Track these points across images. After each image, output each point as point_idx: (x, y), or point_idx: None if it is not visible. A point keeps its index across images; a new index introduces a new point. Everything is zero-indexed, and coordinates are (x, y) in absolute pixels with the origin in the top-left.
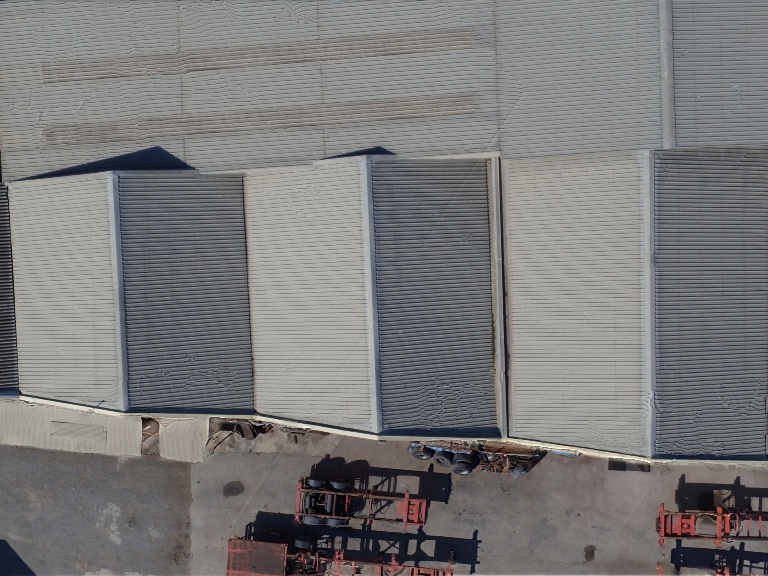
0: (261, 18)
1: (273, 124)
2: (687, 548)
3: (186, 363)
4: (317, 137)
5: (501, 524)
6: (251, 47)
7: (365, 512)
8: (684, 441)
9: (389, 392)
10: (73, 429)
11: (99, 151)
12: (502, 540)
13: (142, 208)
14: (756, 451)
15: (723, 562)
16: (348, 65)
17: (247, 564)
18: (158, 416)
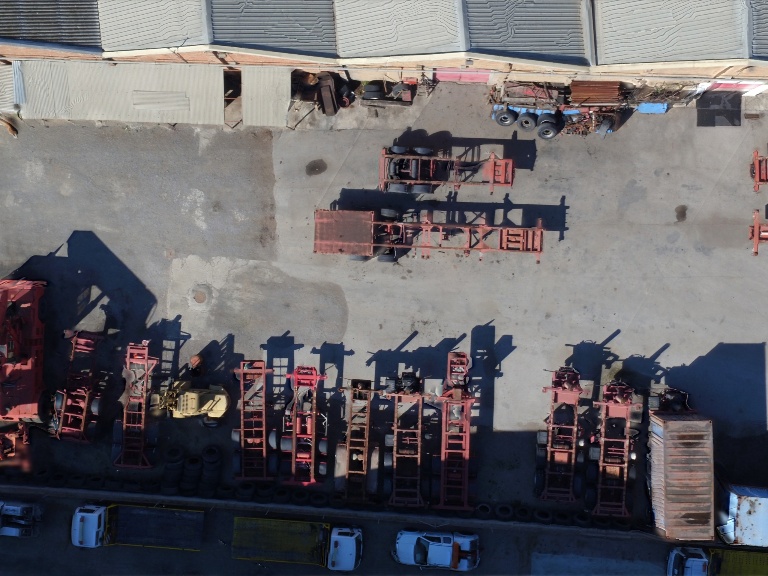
0: None
1: None
2: None
3: (268, 1)
4: None
5: (589, 188)
6: None
7: (450, 183)
8: None
9: (475, 11)
10: (156, 97)
11: None
12: (590, 205)
13: None
14: None
15: None
16: None
17: (334, 234)
18: (243, 52)
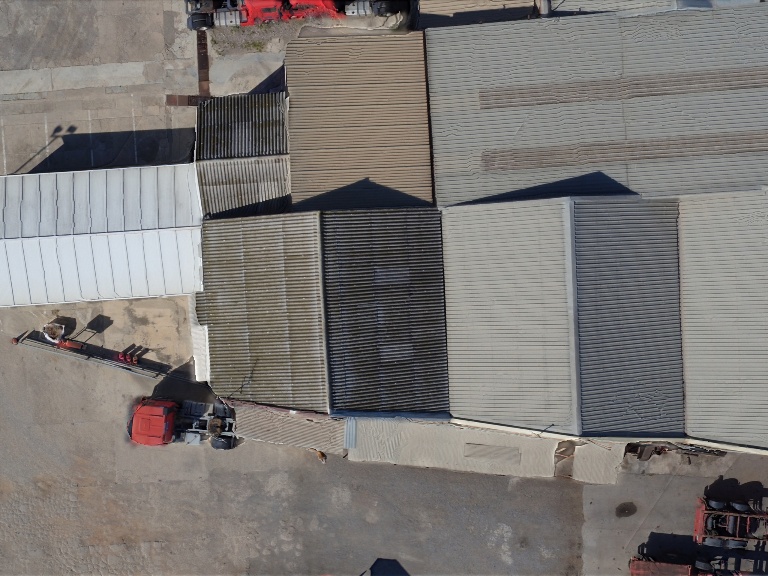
0: (709, 44)
1: (721, 149)
2: None
3: (629, 387)
4: (767, 162)
5: None
6: (698, 73)
7: (759, 533)
8: None
9: None
10: (488, 451)
11: (536, 176)
12: None
13: (594, 233)
14: None
15: None
16: None
17: None
18: (606, 440)
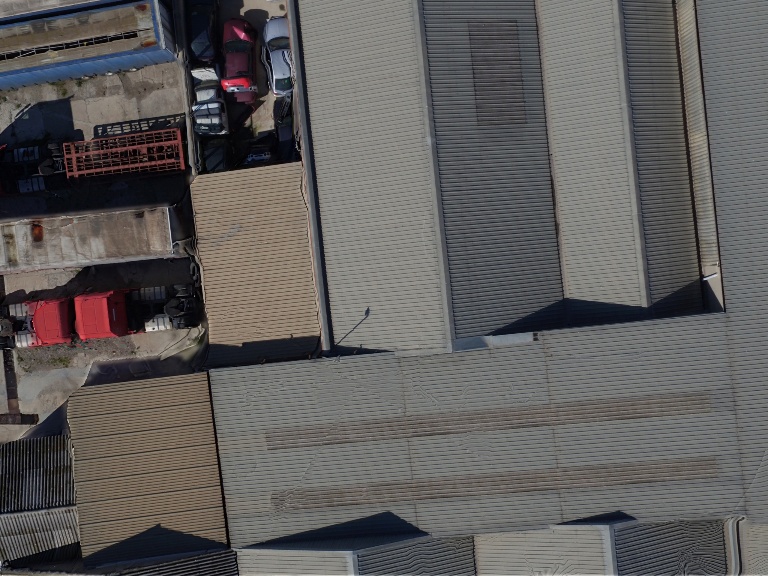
0: (489, 383)
1: (507, 489)
2: None
3: None
4: (553, 501)
5: None
6: (480, 412)
7: None
8: None
9: None
10: None
11: (327, 515)
12: None
13: None
14: None
15: None
16: (582, 429)
17: None
18: None
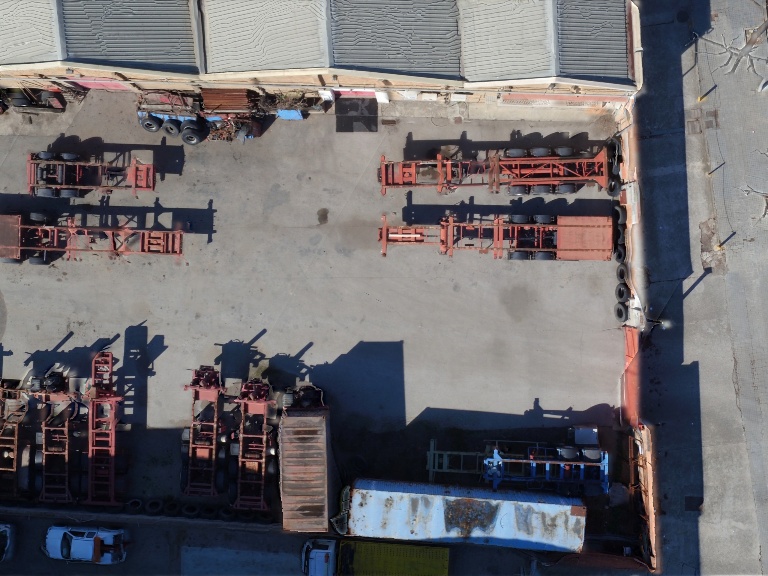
0: None
1: None
2: (418, 205)
3: None
4: None
5: (235, 192)
6: None
7: (102, 188)
8: (358, 46)
9: (73, 21)
10: None
11: None
12: (237, 208)
13: None
14: (448, 71)
15: (454, 217)
16: None
17: None
18: None
